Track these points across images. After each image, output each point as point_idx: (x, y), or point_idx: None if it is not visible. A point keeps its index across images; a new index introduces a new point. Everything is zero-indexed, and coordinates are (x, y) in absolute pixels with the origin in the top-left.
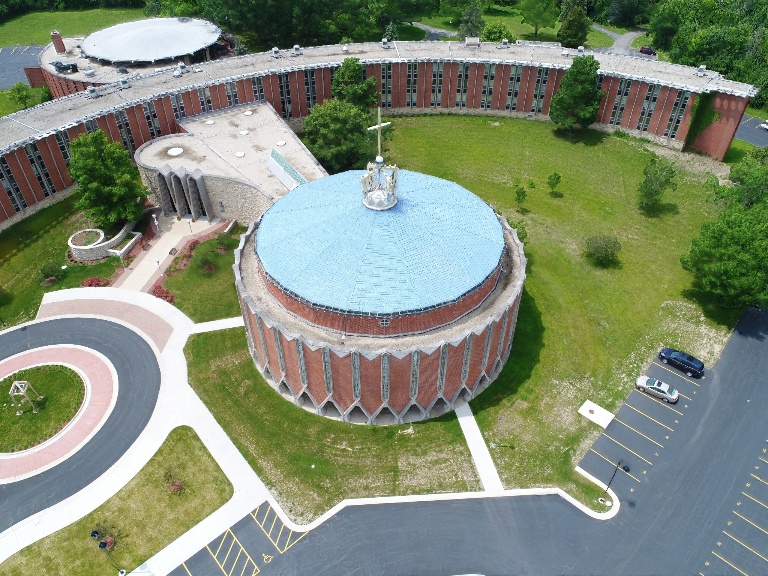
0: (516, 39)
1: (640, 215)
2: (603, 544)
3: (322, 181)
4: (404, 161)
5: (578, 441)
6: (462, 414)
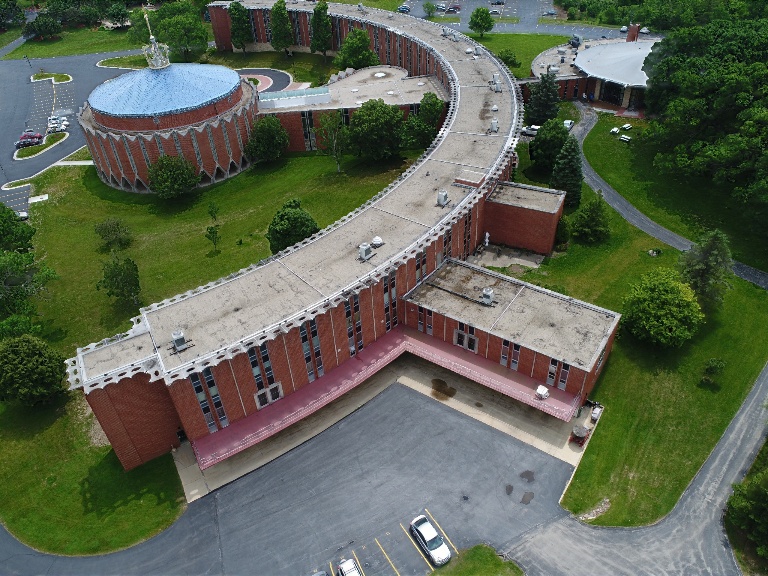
0: (717, 370)
1: None
2: None
3: (231, 76)
4: (348, 186)
5: (37, 188)
6: None
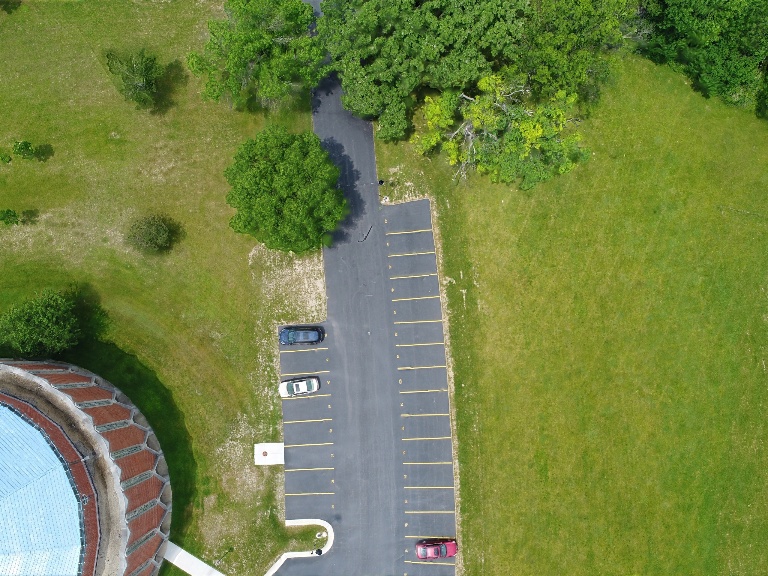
0: None
1: (153, 118)
2: (339, 571)
3: None
4: None
5: (273, 496)
6: (173, 557)
